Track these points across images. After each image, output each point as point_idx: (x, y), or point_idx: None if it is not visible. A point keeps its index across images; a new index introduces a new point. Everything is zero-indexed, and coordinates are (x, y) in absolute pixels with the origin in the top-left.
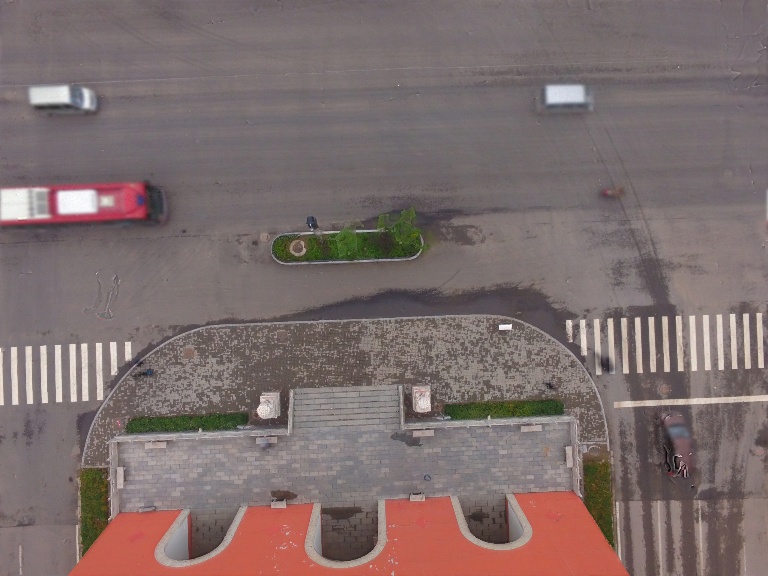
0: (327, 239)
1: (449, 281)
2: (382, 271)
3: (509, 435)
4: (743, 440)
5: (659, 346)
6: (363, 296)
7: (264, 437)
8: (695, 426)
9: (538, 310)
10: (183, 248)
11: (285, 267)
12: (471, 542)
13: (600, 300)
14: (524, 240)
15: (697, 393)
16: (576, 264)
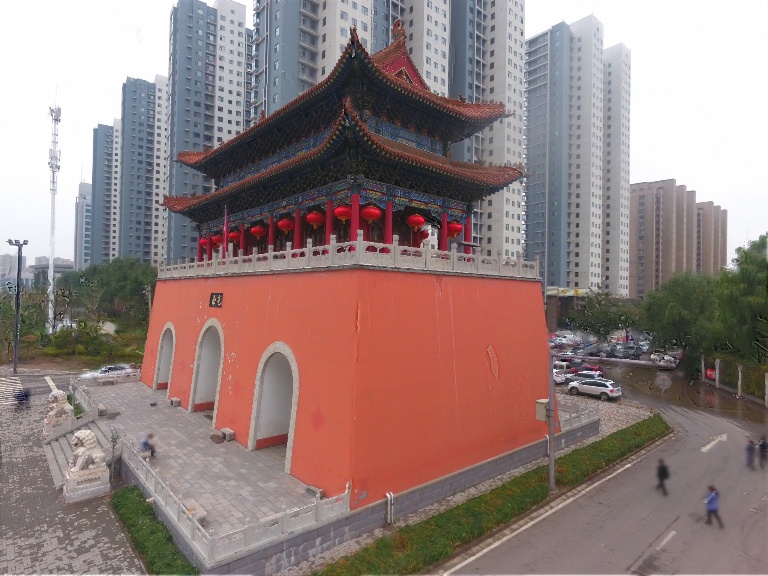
0: None
1: None
2: None
3: None
4: (83, 376)
5: None
6: None
7: None
8: None
9: None
10: None
11: None
12: (175, 333)
13: None
14: None
15: None
16: None
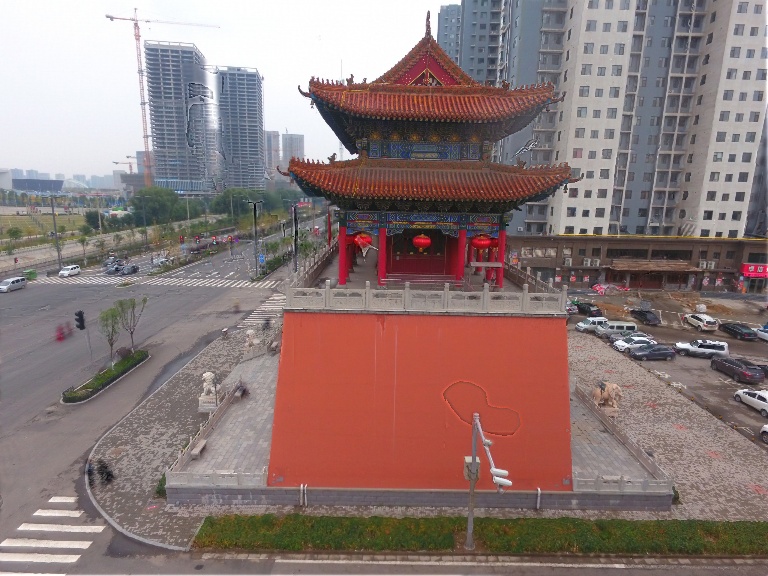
0: (94, 379)
1: None
2: (147, 367)
3: None
4: None
5: None
6: None
7: None
8: None
9: None
10: None
11: None
12: None
13: None
14: None
15: None
16: None
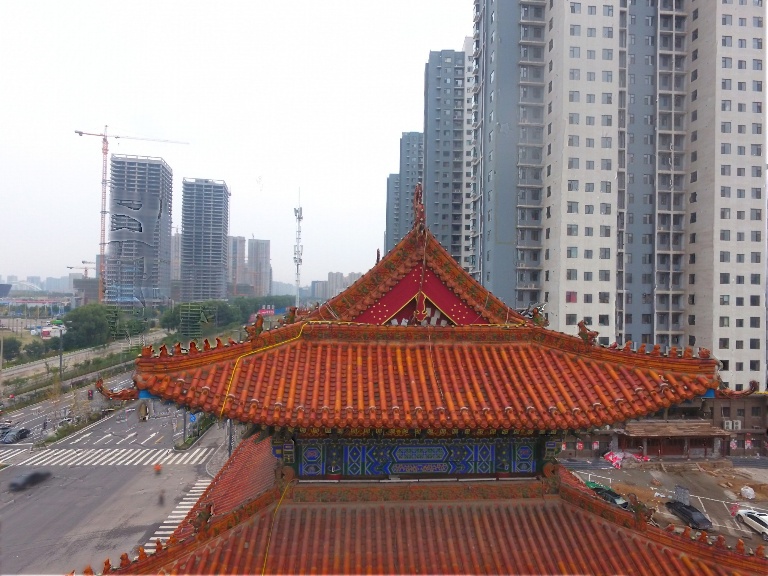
0: None
1: None
2: None
3: None
4: None
5: None
6: None
7: None
8: None
9: None
10: None
11: None
12: None
13: (119, 556)
14: None
15: None
16: None
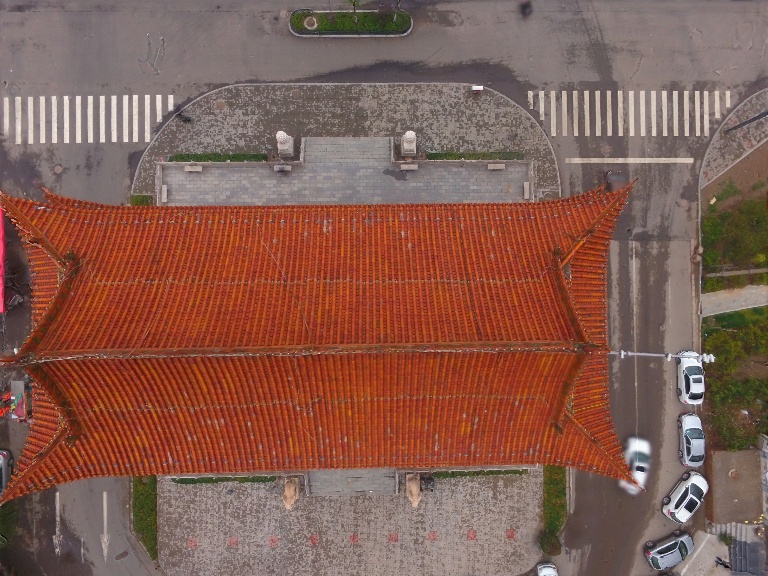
0: (335, 16)
1: (433, 56)
2: (379, 45)
3: (479, 174)
4: (671, 194)
5: (604, 115)
6: (363, 65)
7: (281, 165)
8: (631, 180)
9: (505, 82)
10: (217, 21)
11: (300, 39)
12: None
13: (556, 75)
14: (495, 24)
15: (634, 154)
16: (537, 45)
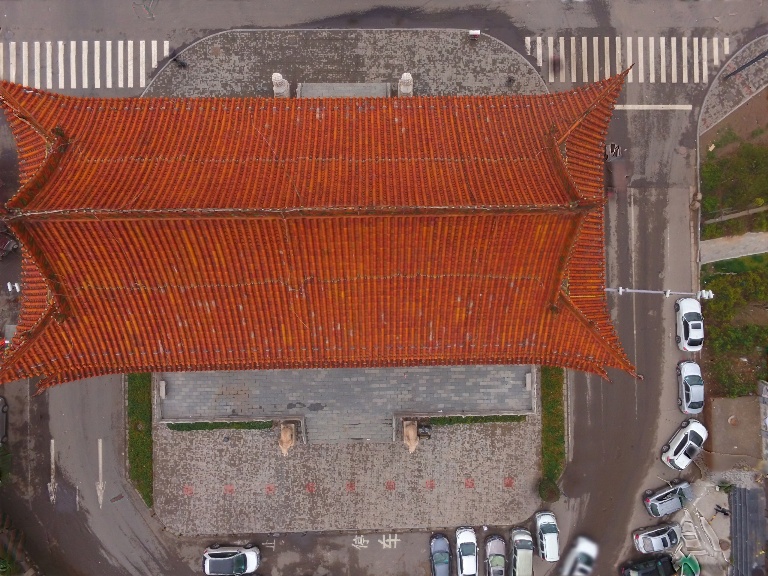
0: None
1: (430, 1)
2: None
3: None
4: (669, 140)
5: (601, 61)
6: (359, 11)
7: None
8: (630, 127)
9: (503, 28)
10: None
11: None
12: None
13: (554, 22)
14: None
15: (632, 100)
16: None
